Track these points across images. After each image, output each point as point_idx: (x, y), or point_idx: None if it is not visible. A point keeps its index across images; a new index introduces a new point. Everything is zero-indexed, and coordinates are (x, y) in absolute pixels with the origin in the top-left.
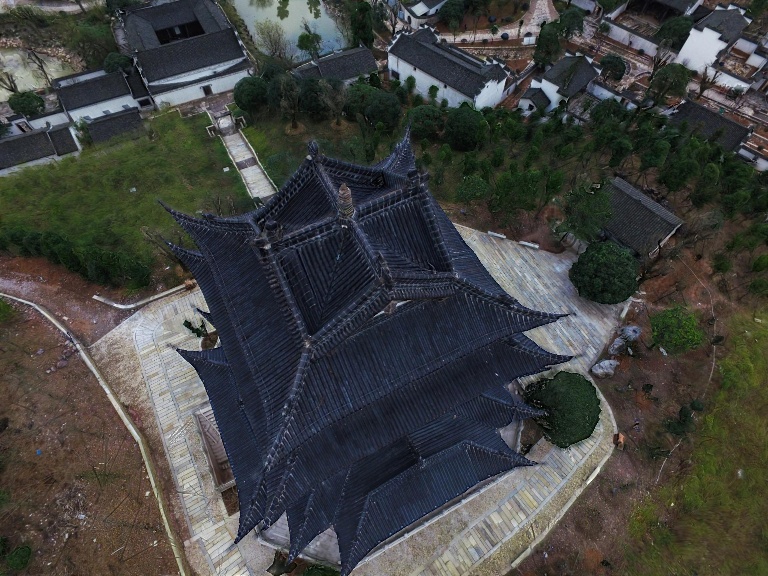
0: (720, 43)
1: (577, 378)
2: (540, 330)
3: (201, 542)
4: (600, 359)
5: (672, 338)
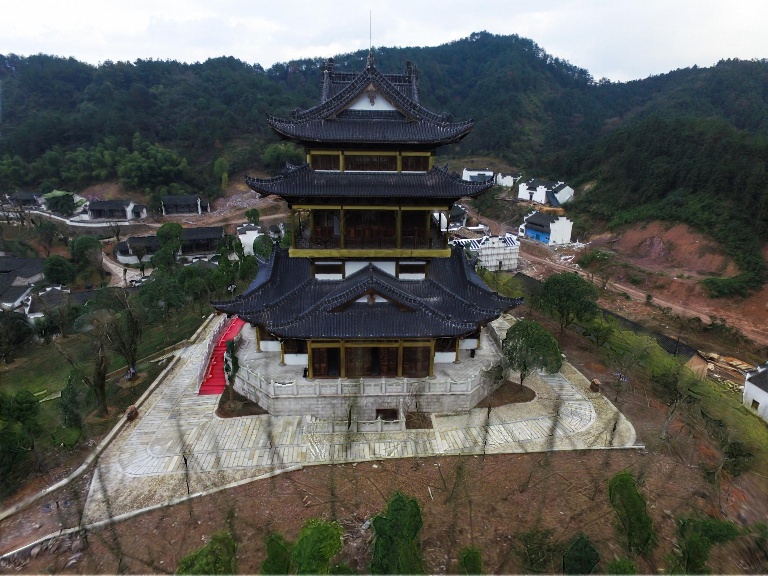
0: None
1: None
2: None
3: (449, 451)
4: None
5: None
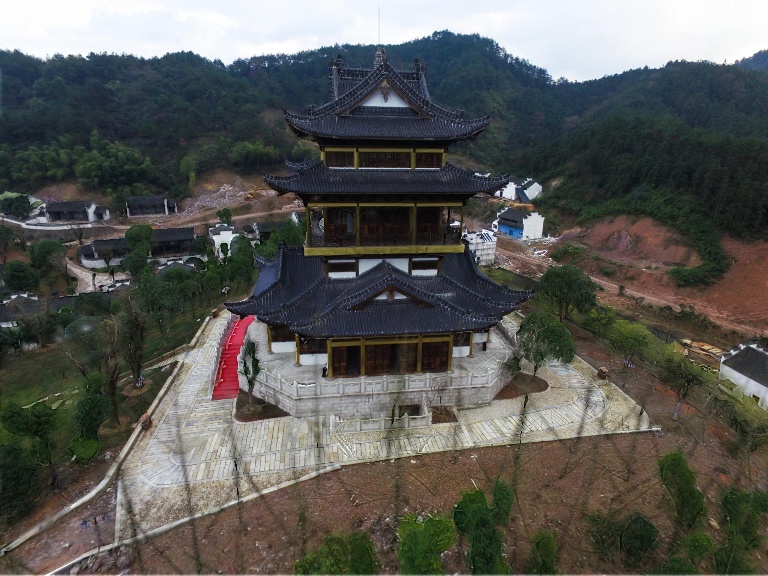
0: (235, 235)
1: None
2: None
3: (478, 443)
4: None
5: None
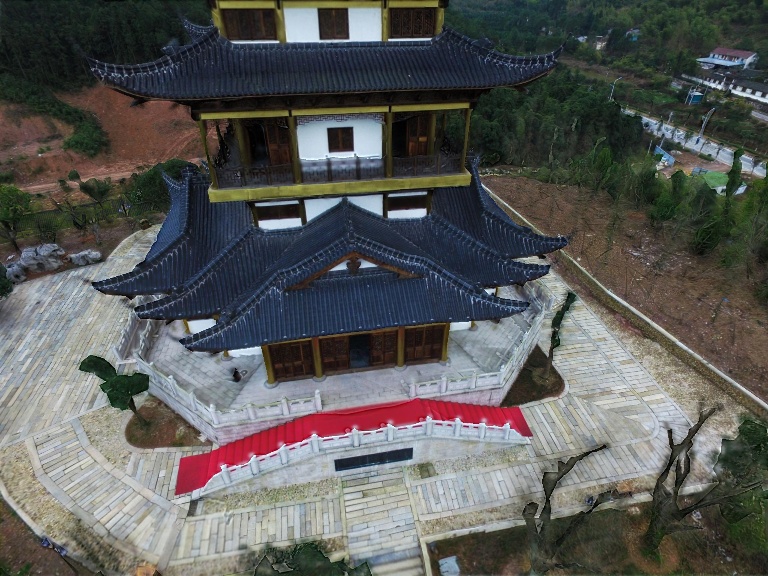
0: None
1: (146, 178)
2: (99, 298)
3: None
4: (78, 266)
5: (17, 190)
